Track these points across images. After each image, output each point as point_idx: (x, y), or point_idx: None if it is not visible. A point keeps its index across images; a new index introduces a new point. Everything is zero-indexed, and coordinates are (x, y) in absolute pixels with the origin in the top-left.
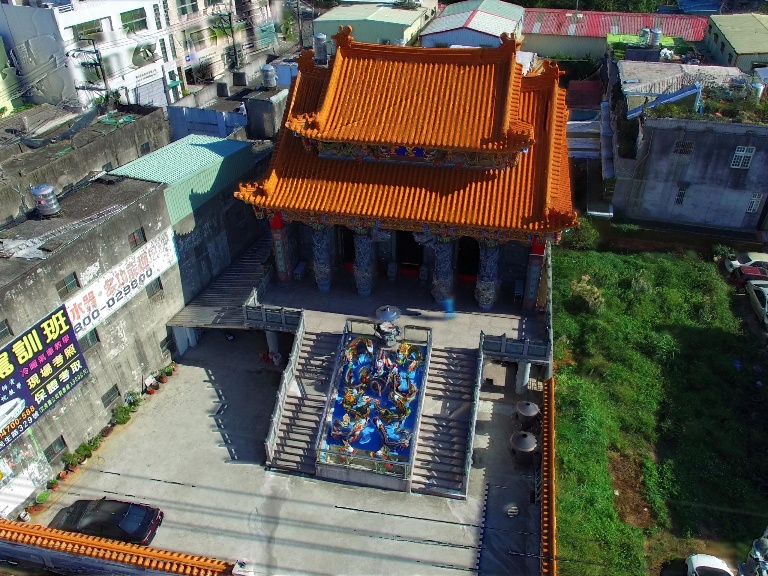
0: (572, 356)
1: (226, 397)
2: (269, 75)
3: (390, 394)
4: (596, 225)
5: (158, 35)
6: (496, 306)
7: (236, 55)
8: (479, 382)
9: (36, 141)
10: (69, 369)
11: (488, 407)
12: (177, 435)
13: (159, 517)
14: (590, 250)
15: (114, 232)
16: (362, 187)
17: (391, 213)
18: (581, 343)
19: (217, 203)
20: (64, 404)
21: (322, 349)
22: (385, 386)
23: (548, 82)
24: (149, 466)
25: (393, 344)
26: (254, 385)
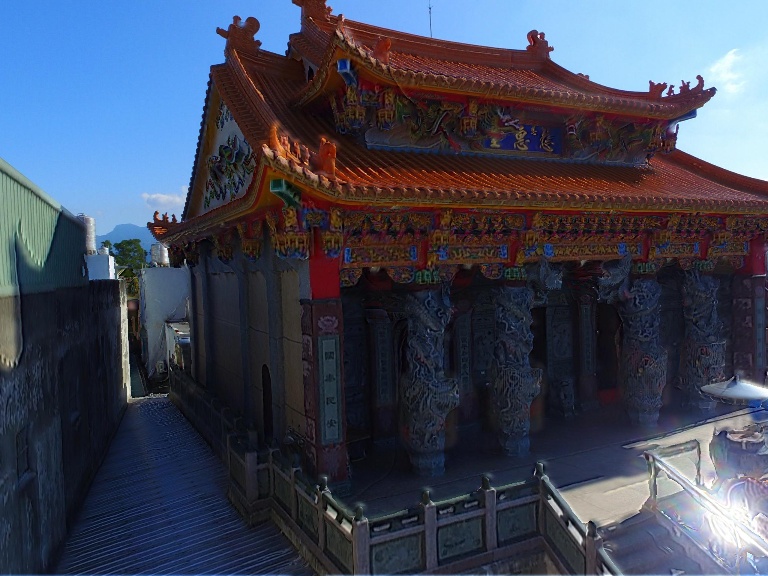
0: None
1: None
2: None
3: None
4: None
5: None
6: None
7: None
8: None
9: None
10: None
11: None
12: None
13: None
14: None
15: None
16: (500, 177)
17: (606, 195)
18: None
19: (51, 319)
20: None
21: None
22: None
23: None
24: None
25: None
26: None
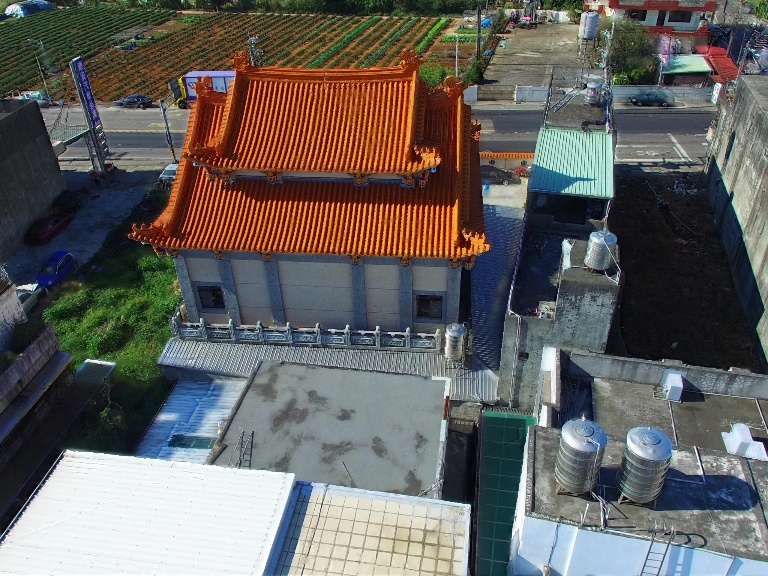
0: None
1: None
2: None
3: None
4: None
5: None
6: None
7: None
8: None
9: None
10: None
11: None
12: None
13: None
14: None
15: None
16: None
17: None
18: None
19: None
20: None
21: None
22: None
23: None
24: None
25: None
26: None
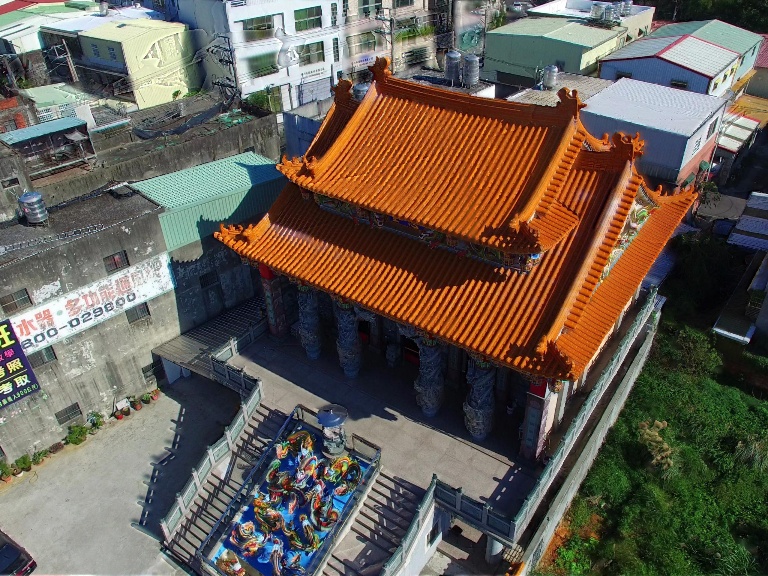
0: (599, 527)
1: (179, 446)
2: (360, 95)
3: (299, 517)
4: (724, 347)
5: (307, 37)
6: (491, 438)
7: (393, 63)
8: (417, 537)
9: (149, 132)
10: (13, 382)
11: (441, 564)
12: (111, 474)
13: (28, 568)
14: (708, 378)
15: (84, 253)
16: (347, 255)
17: (361, 296)
18: (619, 513)
19: None
20: (4, 415)
21: (269, 430)
22: (306, 502)
23: (618, 162)
24: (67, 501)
25: (337, 452)
26: (213, 441)
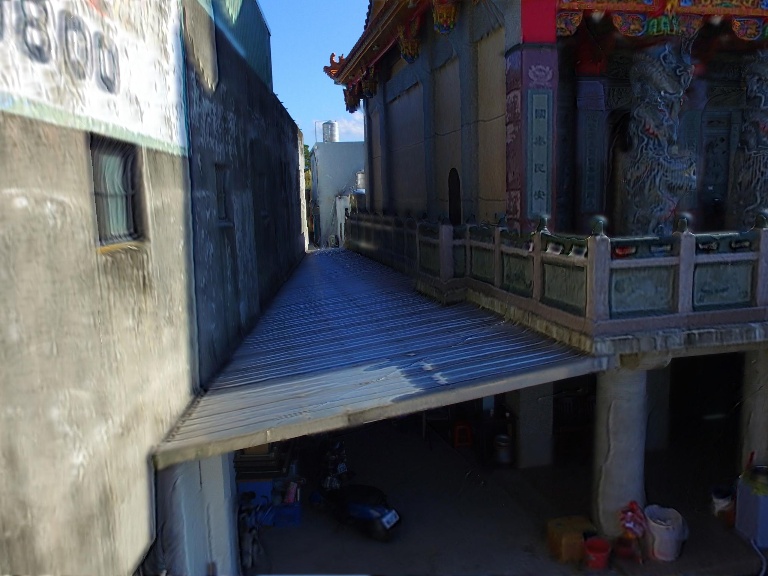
0: None
1: None
2: None
3: None
4: None
5: None
6: None
7: None
8: None
9: None
10: None
11: None
12: None
13: None
14: None
15: None
16: None
17: None
18: None
19: (242, 87)
20: None
21: None
22: None
23: None
24: None
25: None
26: None
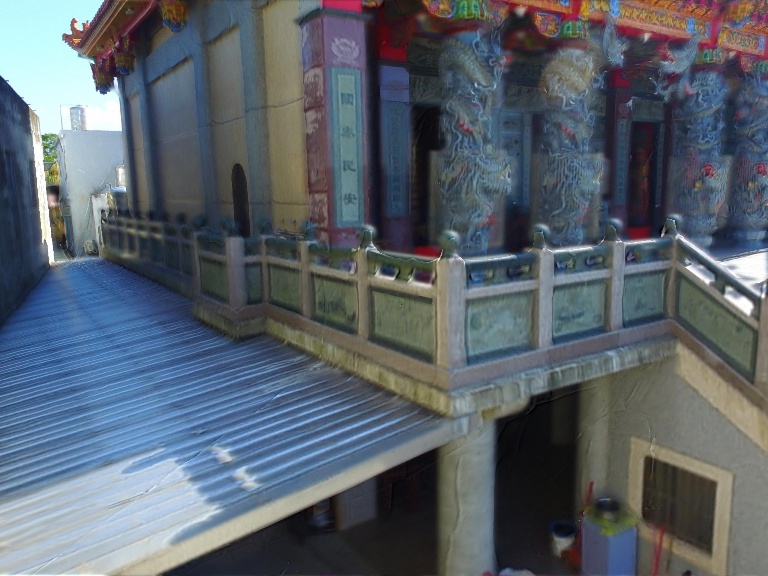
0: None
1: None
2: None
3: None
4: None
5: None
6: None
7: None
8: None
9: None
10: None
11: None
12: None
13: None
14: None
15: None
16: None
17: None
18: None
19: None
20: None
21: None
22: None
23: None
24: None
25: None
26: None
